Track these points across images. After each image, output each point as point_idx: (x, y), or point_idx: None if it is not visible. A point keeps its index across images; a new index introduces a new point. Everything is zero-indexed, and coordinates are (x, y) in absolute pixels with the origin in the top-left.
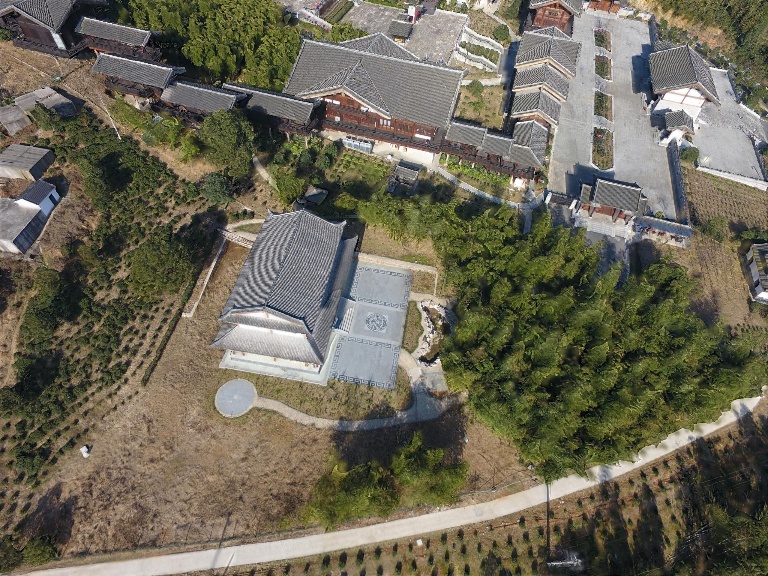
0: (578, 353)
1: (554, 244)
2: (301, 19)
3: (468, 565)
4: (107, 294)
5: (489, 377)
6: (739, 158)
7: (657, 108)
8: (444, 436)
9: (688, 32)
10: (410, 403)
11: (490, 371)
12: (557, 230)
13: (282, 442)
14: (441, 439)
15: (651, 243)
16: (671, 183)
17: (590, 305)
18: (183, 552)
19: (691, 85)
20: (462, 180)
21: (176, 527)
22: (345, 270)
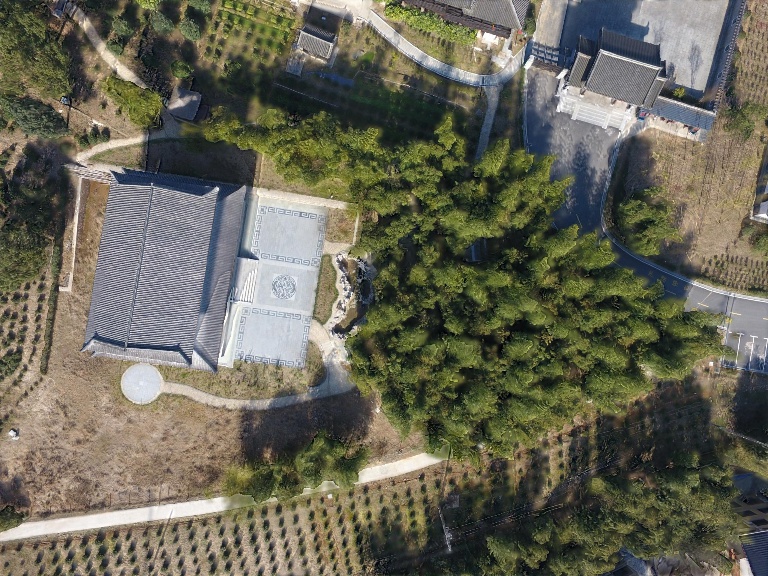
0: (500, 341)
1: (505, 186)
2: None
3: (371, 512)
4: None
5: (396, 377)
6: None
7: None
8: (356, 408)
9: None
10: (322, 379)
11: (397, 373)
12: (515, 159)
13: (197, 423)
14: (353, 411)
15: (653, 136)
16: (725, 13)
17: (530, 278)
18: (130, 508)
19: None
20: (405, 37)
21: (118, 493)
22: (233, 241)
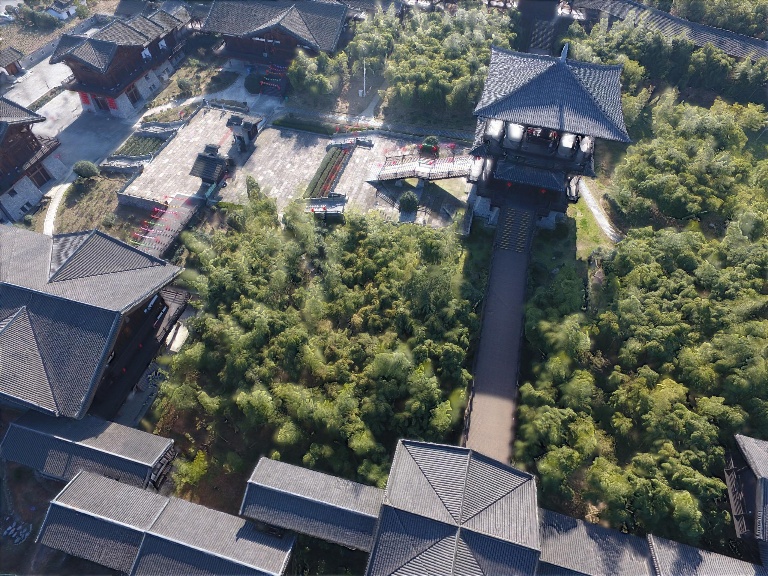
0: None
1: None
2: (372, 132)
3: None
4: None
5: None
6: None
7: None
8: None
9: None
10: None
11: None
12: None
13: None
14: None
15: None
16: None
17: None
18: None
19: None
20: None
21: None
22: None
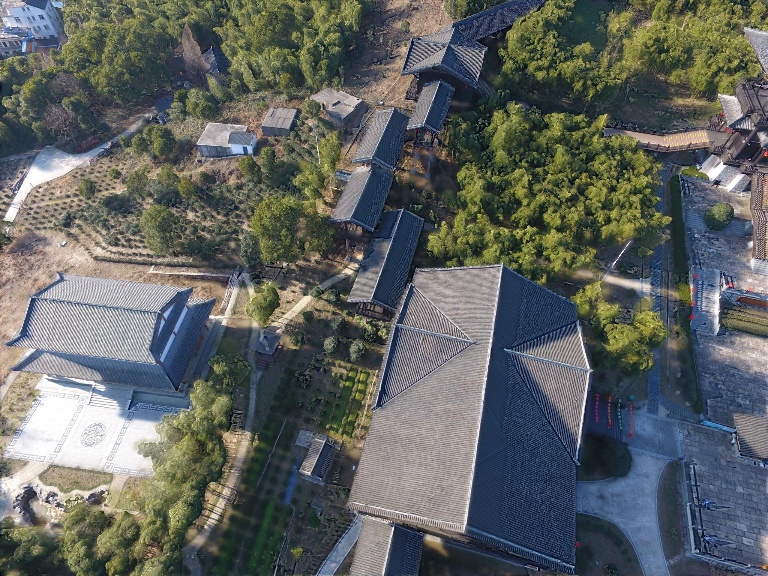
0: None
1: None
2: (691, 275)
3: None
4: (174, 213)
5: None
6: None
7: None
8: None
9: None
10: None
11: None
12: None
13: (2, 361)
14: None
15: None
16: None
17: None
18: None
19: None
20: (338, 570)
21: None
22: (128, 381)
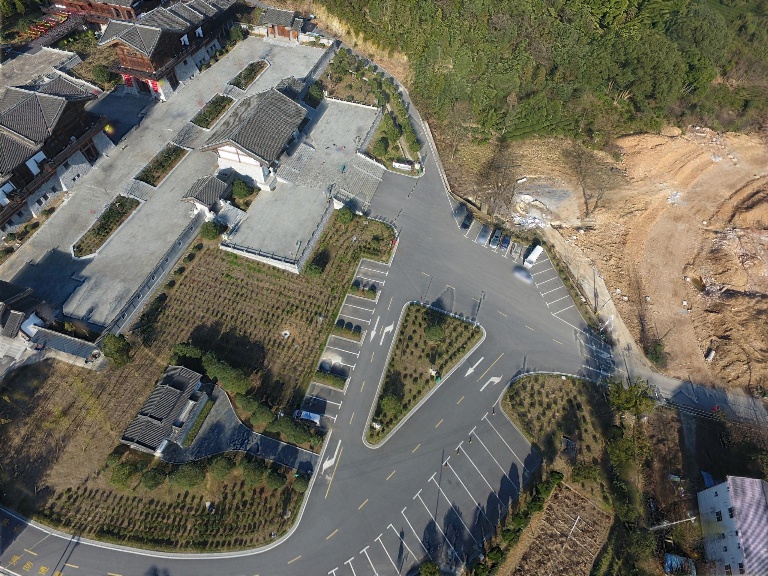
0: None
1: None
2: None
3: None
4: None
5: None
6: (291, 230)
7: (221, 167)
8: None
9: (379, 59)
10: None
11: None
12: None
13: None
14: None
15: (49, 365)
16: None
17: None
18: None
19: (225, 143)
20: None
21: None
22: None
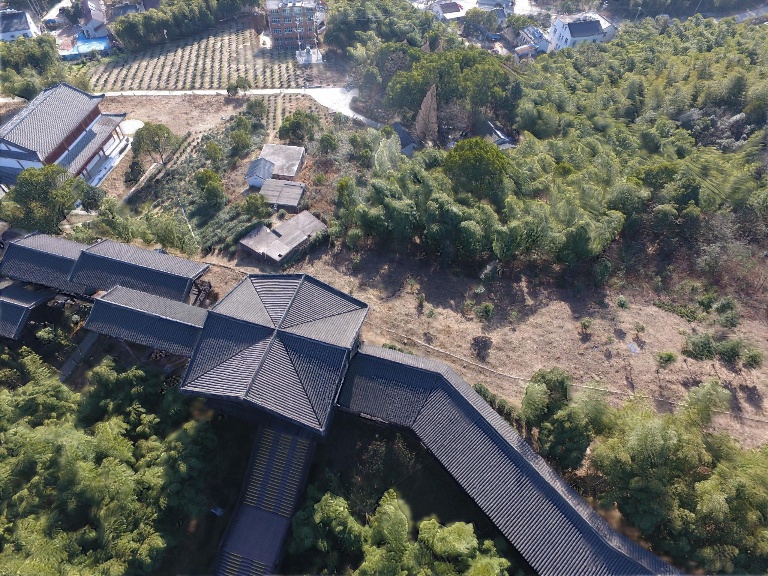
0: None
1: None
2: None
3: None
4: None
5: None
6: None
7: None
8: (6, 118)
9: None
10: None
11: None
12: None
13: None
14: (9, 117)
15: None
16: None
17: None
18: None
19: None
20: None
21: None
22: None
